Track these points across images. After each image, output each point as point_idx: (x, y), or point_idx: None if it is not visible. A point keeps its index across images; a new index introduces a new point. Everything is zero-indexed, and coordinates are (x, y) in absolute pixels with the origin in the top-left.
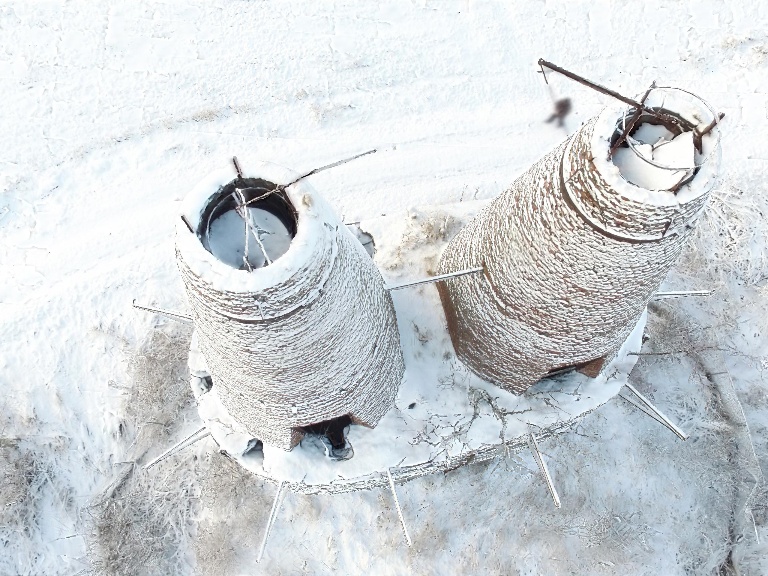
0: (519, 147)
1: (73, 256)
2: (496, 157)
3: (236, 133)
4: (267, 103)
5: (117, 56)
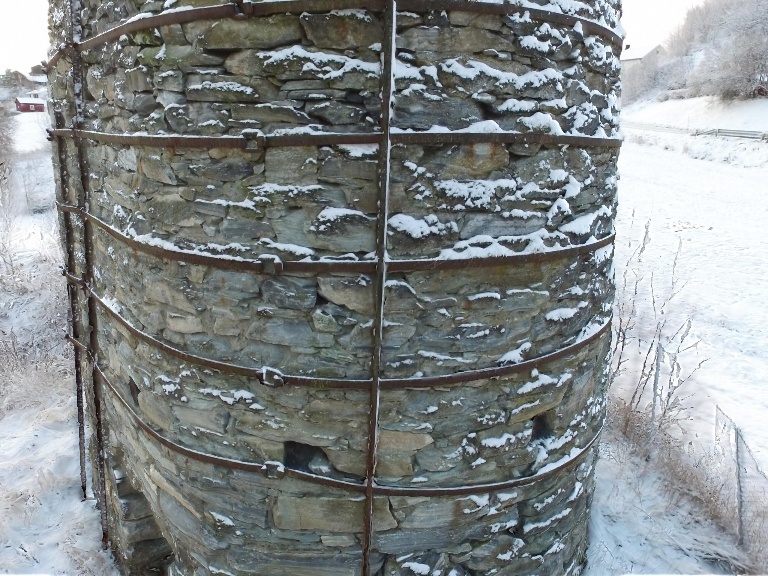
0: None
1: None
2: None
3: None
4: None
5: None
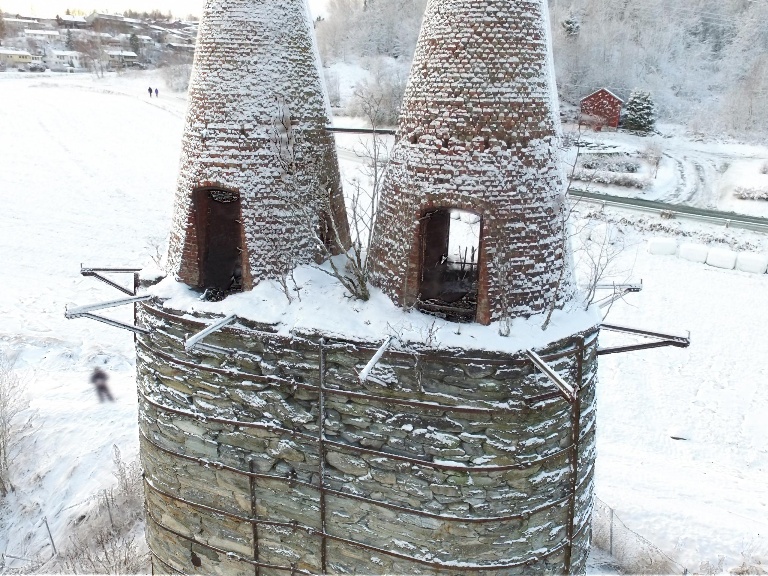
0: (621, 471)
1: None
2: None
3: None
4: None
5: None
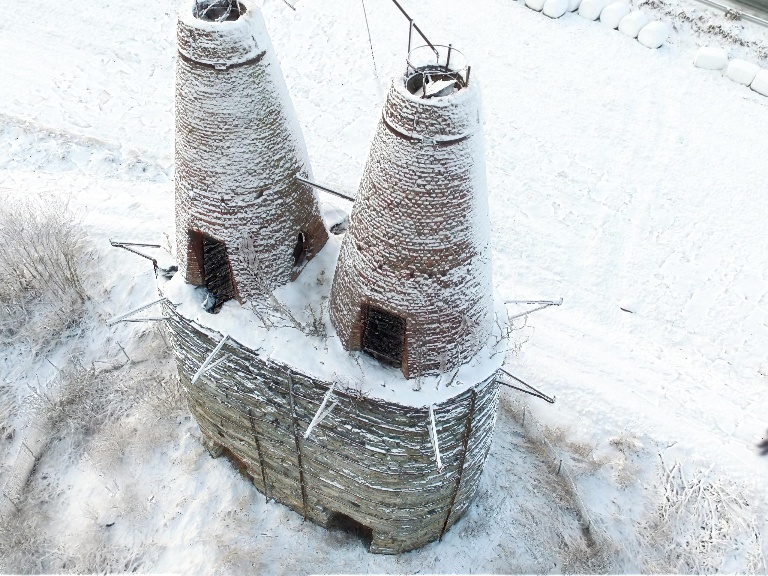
0: (563, 343)
1: None
2: (539, 338)
3: None
4: None
5: (342, 140)
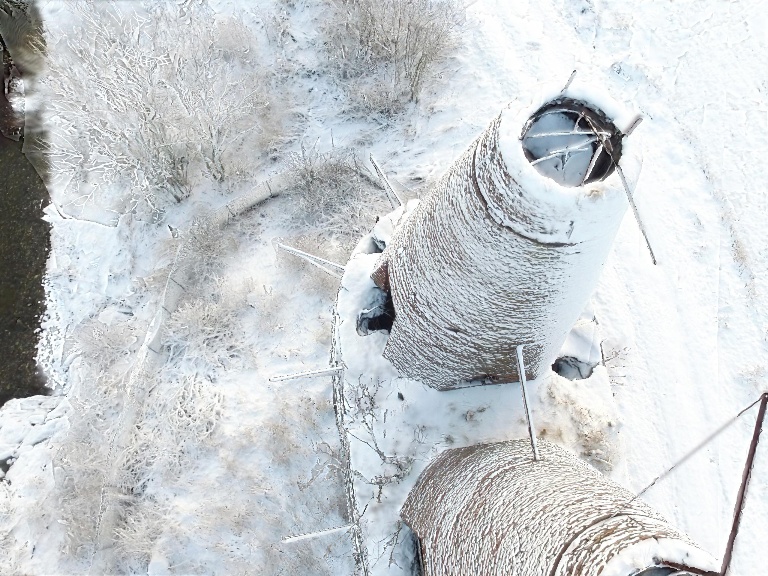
0: None
1: None
2: None
3: (721, 284)
4: (761, 318)
5: None
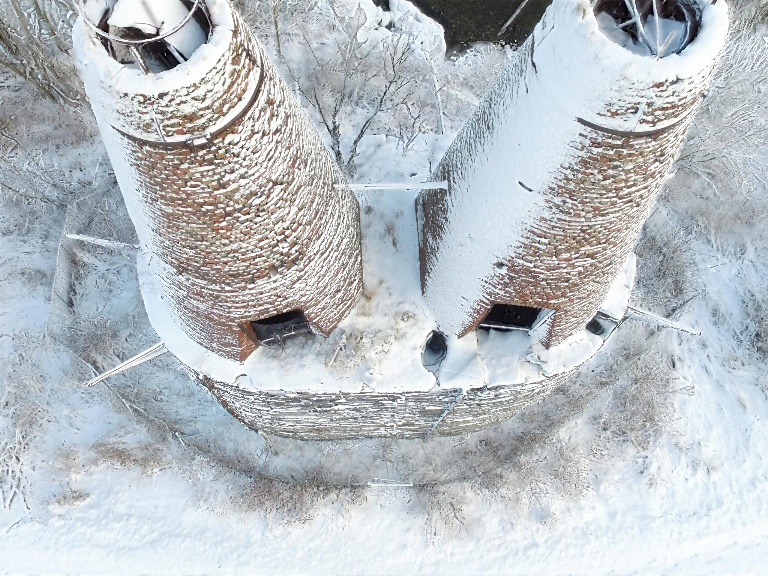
0: None
1: (754, 567)
2: None
3: None
4: None
5: None
